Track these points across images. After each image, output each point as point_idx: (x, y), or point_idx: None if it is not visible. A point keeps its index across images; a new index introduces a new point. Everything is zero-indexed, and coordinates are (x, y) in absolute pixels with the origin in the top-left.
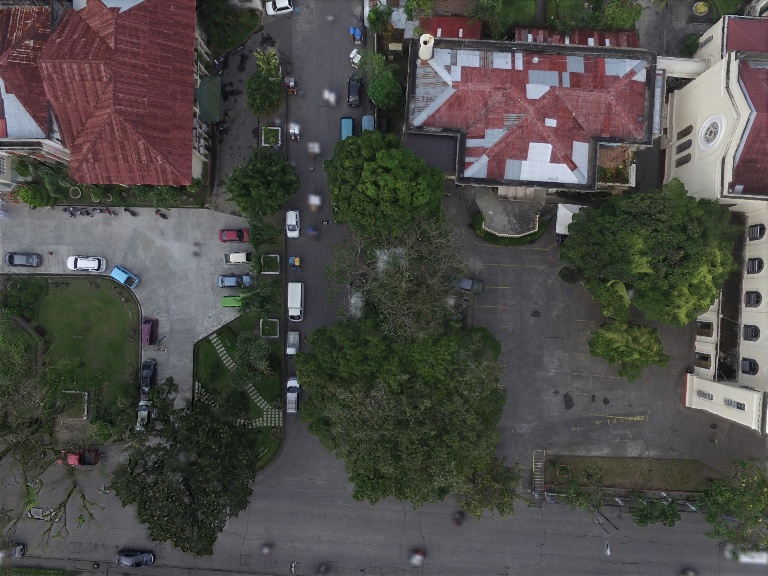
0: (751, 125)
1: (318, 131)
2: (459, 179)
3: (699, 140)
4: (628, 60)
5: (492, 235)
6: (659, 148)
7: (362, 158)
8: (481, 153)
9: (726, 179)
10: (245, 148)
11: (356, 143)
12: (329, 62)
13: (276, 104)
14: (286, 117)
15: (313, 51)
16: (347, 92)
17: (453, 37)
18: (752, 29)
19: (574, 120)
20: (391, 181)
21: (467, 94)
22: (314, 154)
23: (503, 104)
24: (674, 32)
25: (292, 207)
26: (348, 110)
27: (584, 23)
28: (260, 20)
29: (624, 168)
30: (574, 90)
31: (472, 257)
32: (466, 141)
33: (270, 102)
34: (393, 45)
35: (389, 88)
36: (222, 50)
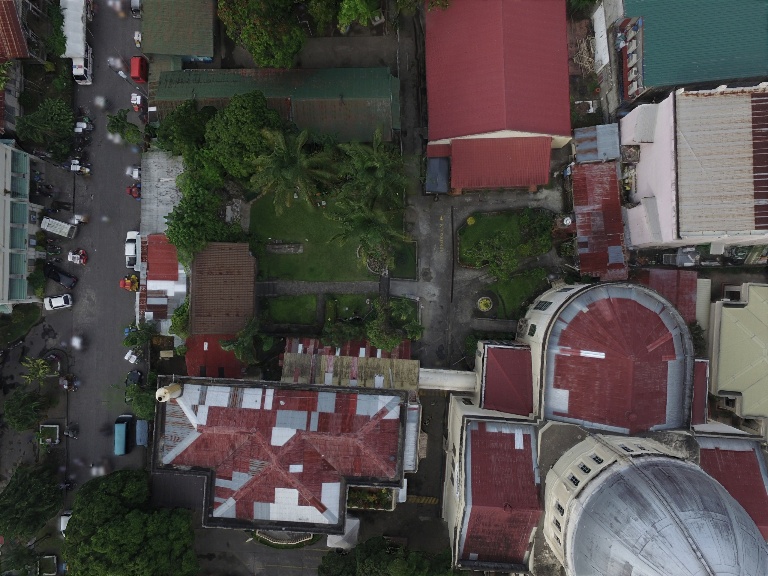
0: (469, 513)
1: (98, 426)
2: (208, 519)
3: (455, 475)
4: (381, 397)
5: (267, 541)
6: (441, 447)
7: (80, 537)
8: (228, 495)
9: (456, 552)
10: (25, 442)
11: (82, 511)
12: (110, 356)
13: (40, 420)
14: (66, 411)
15: (94, 344)
16: (125, 389)
17: (220, 350)
18: (510, 362)
19: (323, 461)
20: (101, 572)
21: (213, 437)
22: (94, 450)
23: (249, 448)
24: (459, 327)
25: (71, 505)
26: (128, 405)
27: (352, 337)
28: (41, 312)
29: (390, 489)
30: (320, 435)
31: (251, 558)
32: (215, 480)
33: (30, 423)
34: (164, 352)
35: (148, 411)
36: (3, 342)
